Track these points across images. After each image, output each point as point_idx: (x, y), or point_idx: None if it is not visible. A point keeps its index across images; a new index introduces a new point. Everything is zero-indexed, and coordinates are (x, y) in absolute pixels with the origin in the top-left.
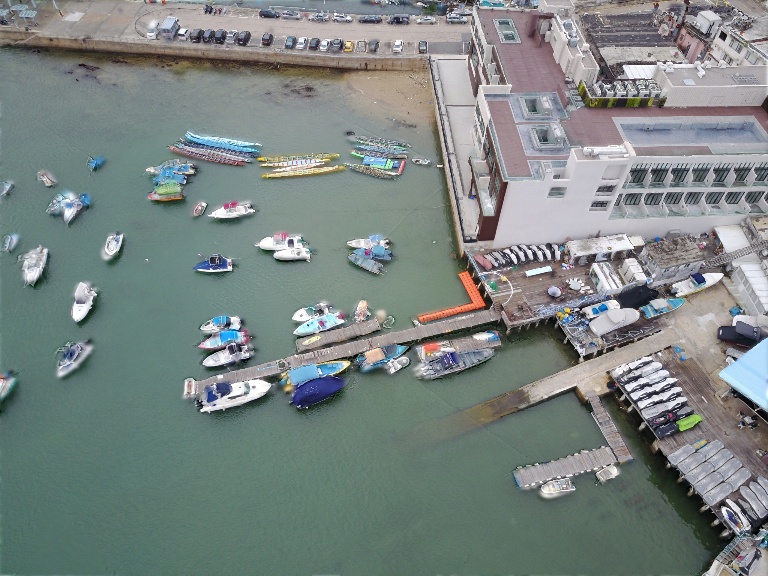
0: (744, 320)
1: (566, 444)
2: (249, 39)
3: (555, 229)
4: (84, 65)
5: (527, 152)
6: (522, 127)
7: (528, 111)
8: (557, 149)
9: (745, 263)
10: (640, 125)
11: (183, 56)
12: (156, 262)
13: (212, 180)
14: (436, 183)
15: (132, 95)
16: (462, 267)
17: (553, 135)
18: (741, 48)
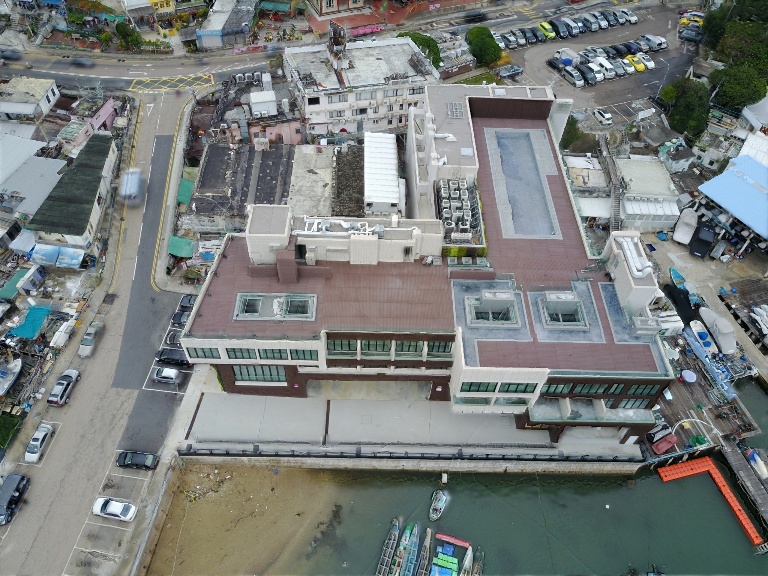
0: (683, 234)
1: None
2: None
3: None
4: None
5: (597, 340)
6: (540, 336)
7: None
8: None
9: (624, 209)
10: None
11: None
12: None
13: None
14: (470, 490)
15: None
16: (645, 476)
17: (572, 303)
18: (346, 96)
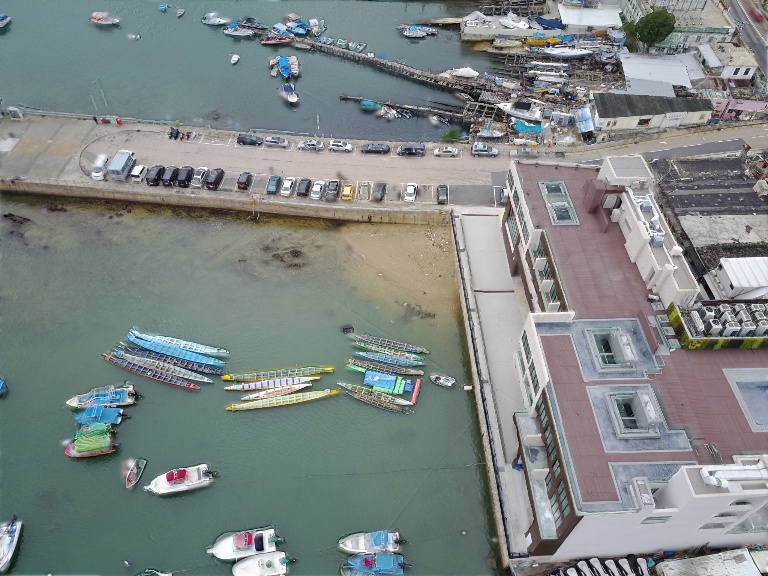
0: None
1: None
2: (222, 179)
3: (644, 544)
4: (11, 215)
5: (606, 444)
6: (594, 390)
7: (600, 356)
8: (650, 437)
9: None
10: (764, 382)
11: (138, 201)
12: (64, 575)
13: (158, 413)
14: (463, 414)
15: (66, 264)
16: None
17: (644, 416)
18: None
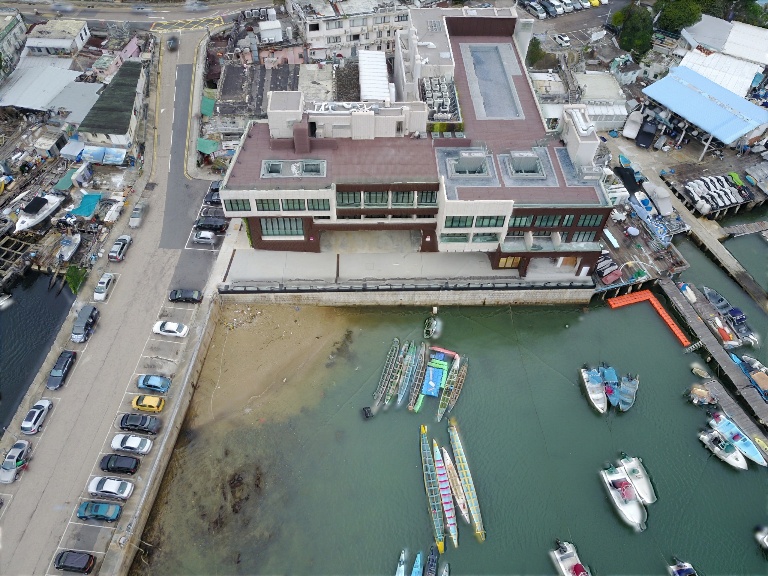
0: (630, 130)
1: (767, 257)
2: None
3: None
4: None
5: (552, 185)
6: (507, 183)
7: None
8: None
9: None
10: None
11: None
12: None
13: None
14: (456, 320)
15: None
16: (598, 305)
17: (532, 159)
18: (341, 23)
